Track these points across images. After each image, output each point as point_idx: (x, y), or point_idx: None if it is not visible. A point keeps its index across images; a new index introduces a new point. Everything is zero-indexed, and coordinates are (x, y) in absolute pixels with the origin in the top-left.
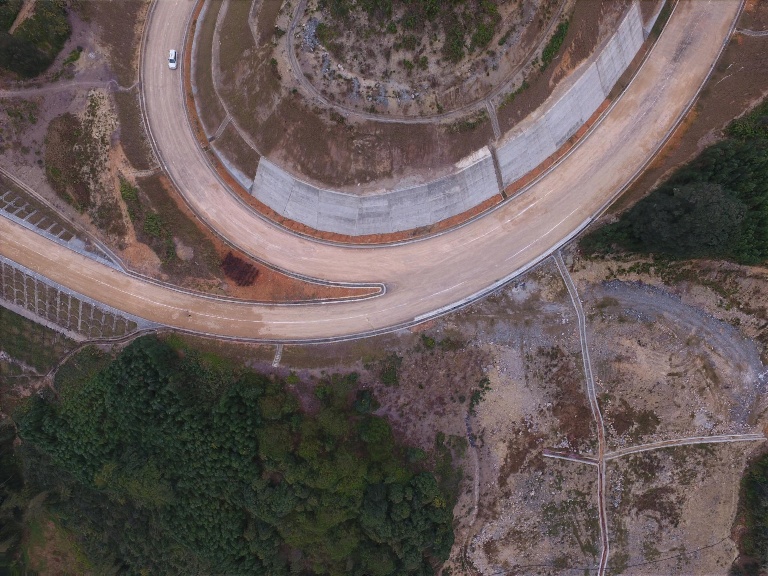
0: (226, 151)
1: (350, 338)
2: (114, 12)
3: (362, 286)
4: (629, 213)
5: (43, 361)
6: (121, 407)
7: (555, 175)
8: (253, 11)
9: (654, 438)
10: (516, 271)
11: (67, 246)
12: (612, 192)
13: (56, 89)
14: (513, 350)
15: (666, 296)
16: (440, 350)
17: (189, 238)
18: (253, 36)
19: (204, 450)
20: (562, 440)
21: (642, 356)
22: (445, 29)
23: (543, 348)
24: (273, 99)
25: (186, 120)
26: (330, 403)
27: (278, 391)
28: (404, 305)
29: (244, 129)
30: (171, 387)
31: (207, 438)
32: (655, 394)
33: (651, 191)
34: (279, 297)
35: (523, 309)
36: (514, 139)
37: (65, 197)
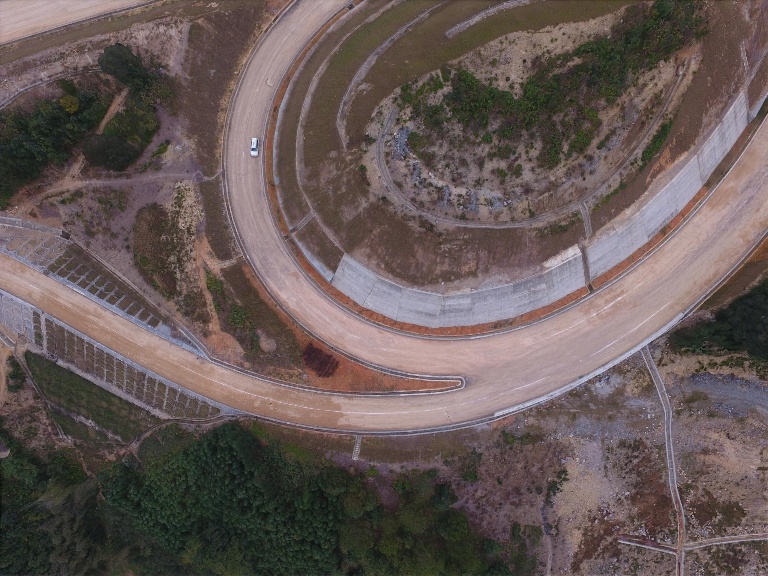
0: (308, 243)
1: (429, 432)
2: (199, 103)
3: (441, 379)
4: (729, 315)
5: (128, 432)
6: (204, 487)
7: (645, 267)
8: (341, 113)
9: (739, 530)
10: (601, 368)
11: (155, 333)
12: (707, 286)
13: (144, 180)
14: (594, 443)
15: (760, 390)
16: (519, 444)
17: (272, 330)
18: (341, 139)
19: (286, 541)
20: (639, 528)
21: (730, 449)
22: (543, 138)
23: (625, 441)
24: (360, 202)
25: (267, 208)
26: (409, 499)
27: (360, 489)
28: (484, 399)
29: (328, 226)
30: (257, 483)
31: (290, 530)
32: (742, 487)
33: (752, 287)
34: (358, 388)
35: (606, 404)
36: (606, 237)
37: (152, 284)
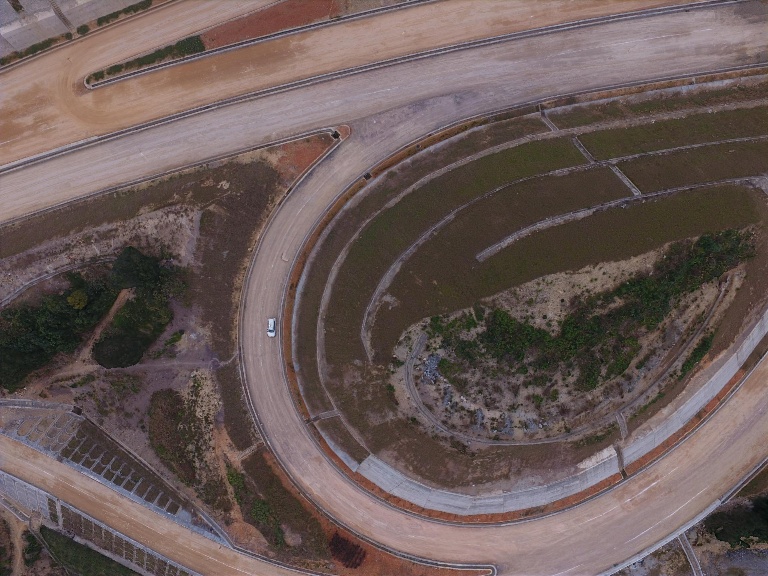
0: (331, 433)
1: None
2: (213, 288)
3: (472, 567)
4: None
5: None
6: None
7: (680, 451)
8: (365, 324)
9: None
10: (637, 556)
11: (175, 521)
12: (745, 471)
13: (158, 366)
14: None
15: None
16: None
17: (296, 524)
18: (366, 352)
19: None
20: None
21: None
22: (580, 367)
23: None
24: (387, 413)
25: (287, 390)
26: None
27: None
28: None
29: (352, 425)
30: None
31: None
32: None
33: None
34: None
35: None
36: (642, 438)
37: (170, 469)
